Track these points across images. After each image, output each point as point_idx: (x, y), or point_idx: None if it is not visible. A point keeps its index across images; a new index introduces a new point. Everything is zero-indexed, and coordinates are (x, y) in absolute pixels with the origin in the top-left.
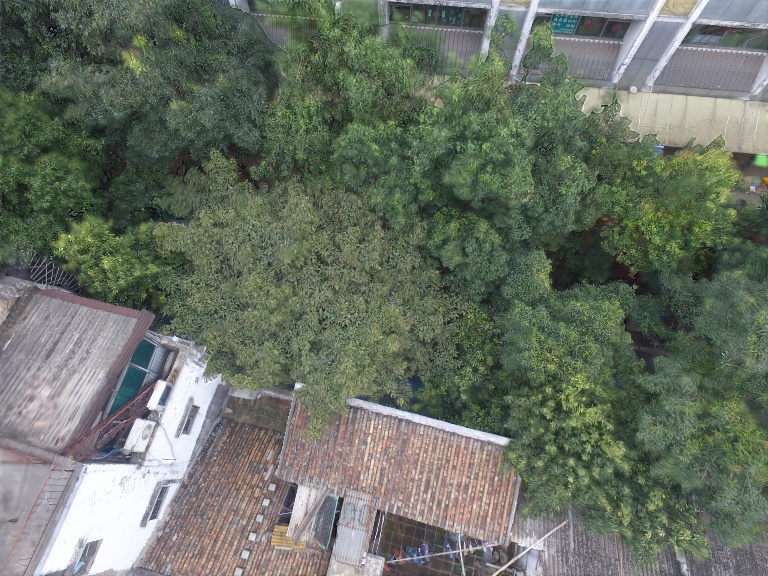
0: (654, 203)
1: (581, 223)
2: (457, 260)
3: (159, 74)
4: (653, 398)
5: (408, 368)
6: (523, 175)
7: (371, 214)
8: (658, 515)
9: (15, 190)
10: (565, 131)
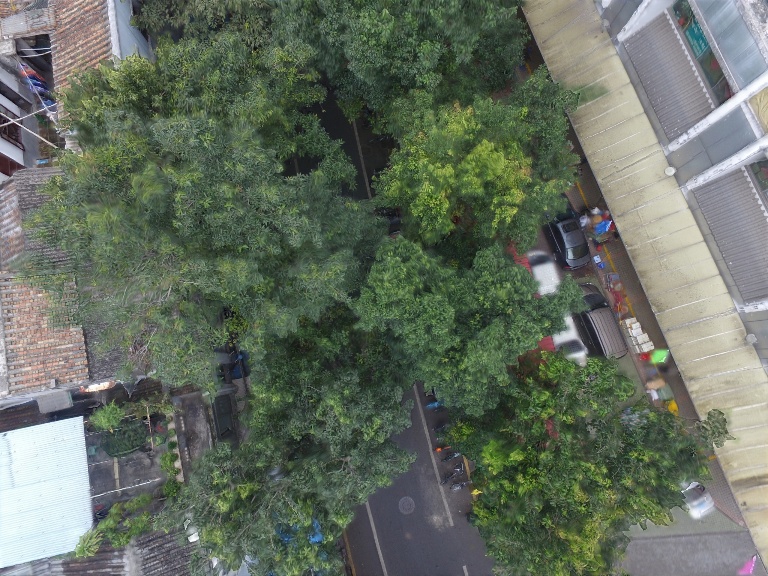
0: None
1: None
2: None
3: None
4: None
5: None
6: None
7: None
8: None
9: None
10: None
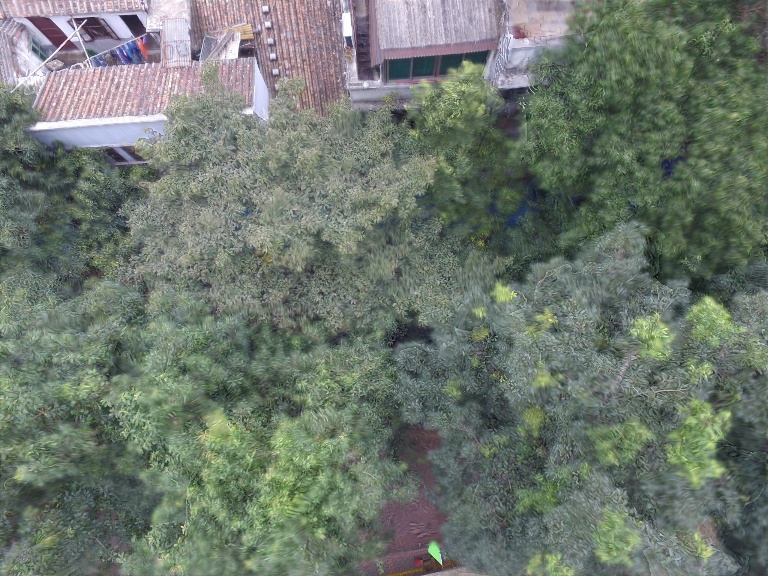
0: None
1: None
2: None
3: None
4: None
5: None
6: None
7: None
8: None
9: None
10: None
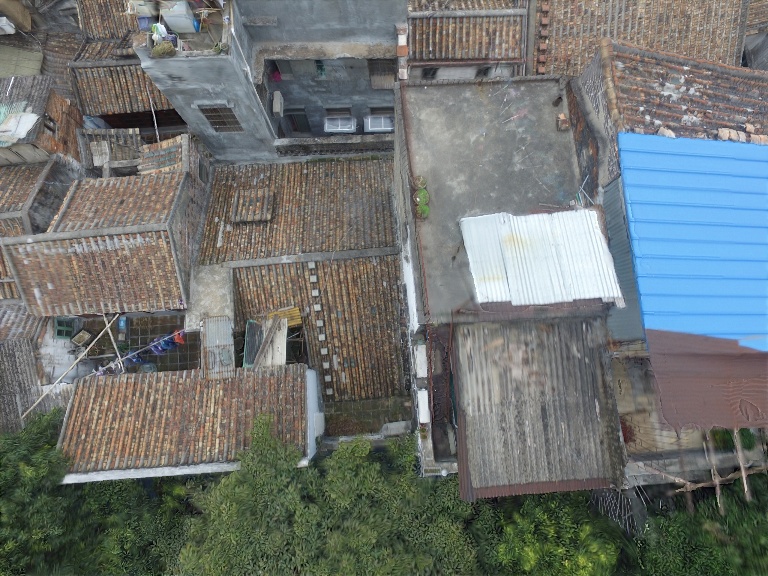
0: None
1: None
2: None
3: None
4: None
5: None
6: None
7: None
8: None
9: None
10: None
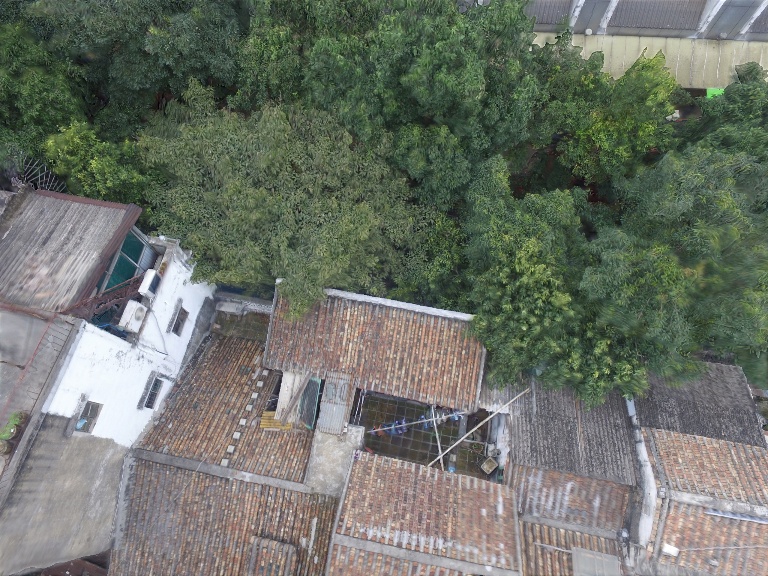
0: (602, 112)
1: (538, 139)
2: (422, 166)
3: (136, 4)
4: (597, 259)
5: (382, 270)
6: (475, 74)
7: (341, 128)
8: (604, 358)
9: (6, 102)
10: (515, 42)
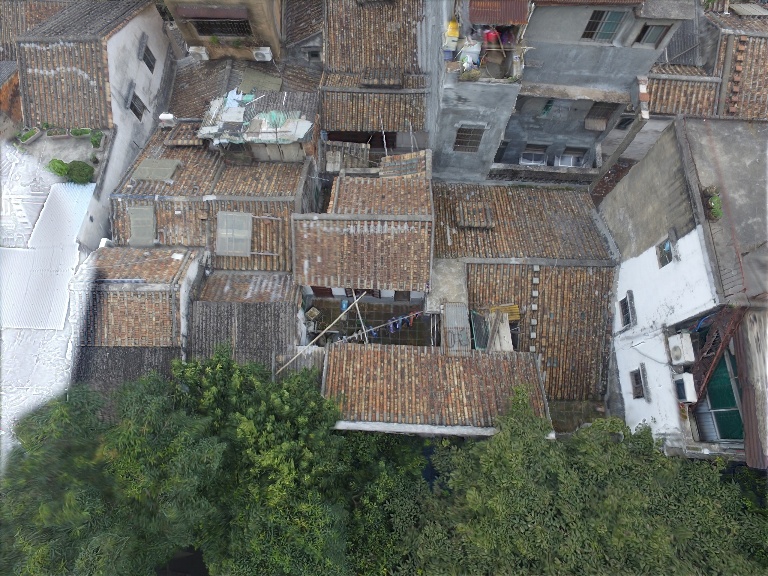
0: None
1: None
2: None
3: None
4: None
5: (442, 487)
6: None
7: None
8: (209, 384)
9: None
10: None
